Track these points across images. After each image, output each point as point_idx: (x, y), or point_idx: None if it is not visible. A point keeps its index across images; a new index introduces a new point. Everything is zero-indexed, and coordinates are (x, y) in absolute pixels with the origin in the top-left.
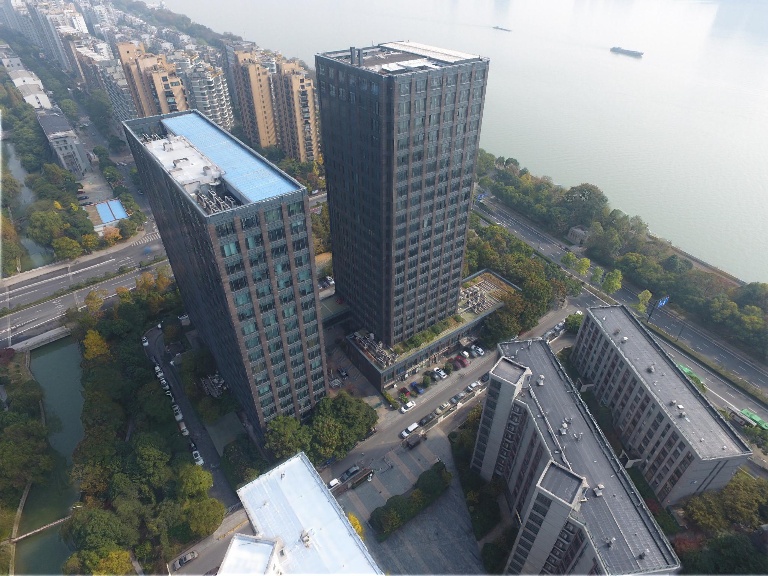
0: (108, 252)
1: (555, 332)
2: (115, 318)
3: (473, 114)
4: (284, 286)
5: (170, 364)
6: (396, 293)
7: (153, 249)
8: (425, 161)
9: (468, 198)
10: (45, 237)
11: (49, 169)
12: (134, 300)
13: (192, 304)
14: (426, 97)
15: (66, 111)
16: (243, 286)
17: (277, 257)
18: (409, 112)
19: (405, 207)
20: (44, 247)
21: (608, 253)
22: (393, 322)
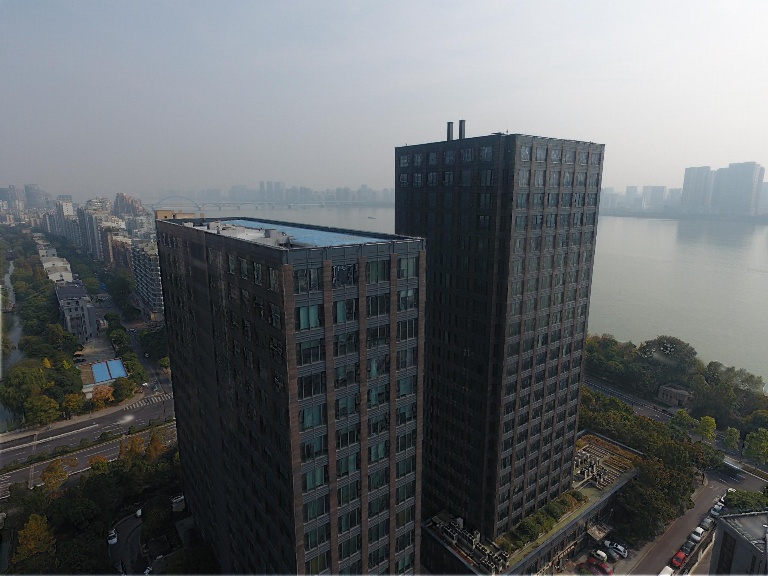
0: (92, 417)
1: (714, 520)
2: (78, 498)
3: (589, 205)
4: (376, 401)
5: (144, 575)
6: (503, 446)
7: (149, 413)
8: (542, 252)
9: (584, 314)
10: (19, 398)
11: (51, 329)
12: (111, 473)
13: (198, 468)
14: (545, 169)
15: (87, 283)
16: (317, 390)
17: (373, 346)
18: (528, 184)
19: (519, 312)
20: (14, 412)
21: (727, 413)
22: (498, 495)
